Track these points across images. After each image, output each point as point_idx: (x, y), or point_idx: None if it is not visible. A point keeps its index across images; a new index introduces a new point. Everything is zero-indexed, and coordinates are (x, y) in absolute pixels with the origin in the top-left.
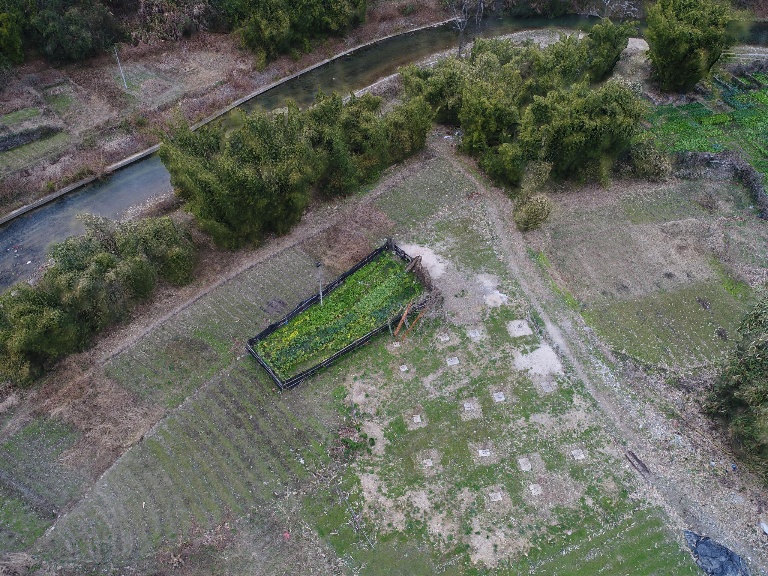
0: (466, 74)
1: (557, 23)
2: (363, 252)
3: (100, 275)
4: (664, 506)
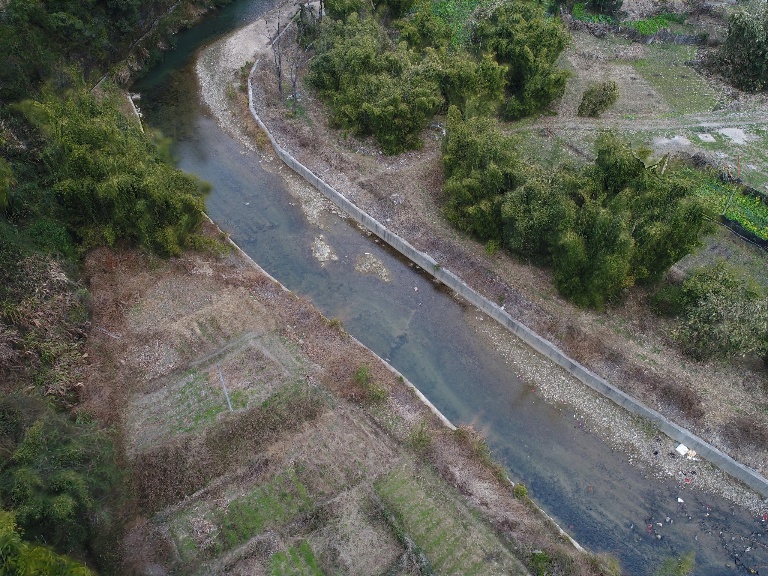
0: (433, 69)
1: (184, 49)
2: None
3: None
4: None
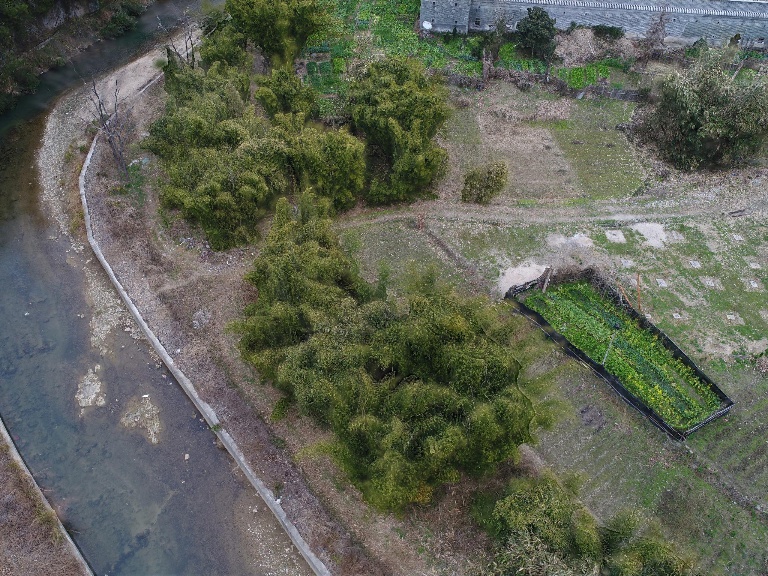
0: (271, 147)
1: (47, 93)
2: (505, 324)
3: (686, 567)
4: (766, 213)
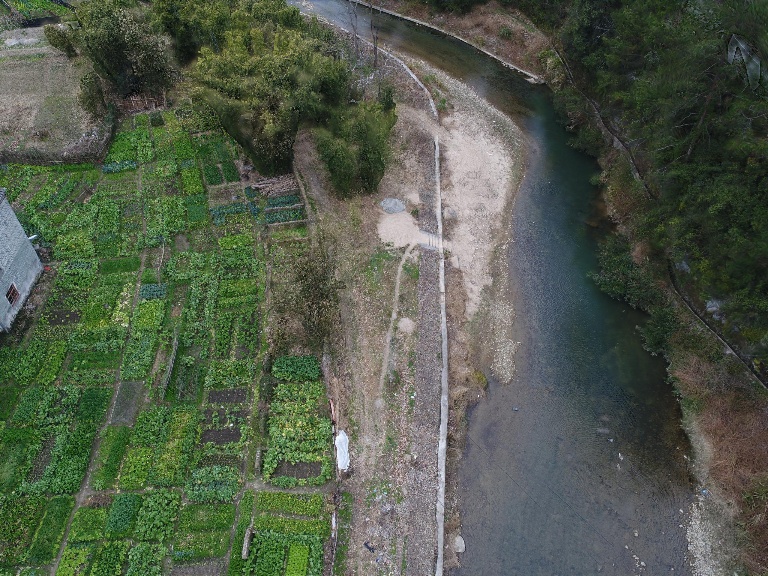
0: None
1: (559, 151)
2: None
3: None
4: None
